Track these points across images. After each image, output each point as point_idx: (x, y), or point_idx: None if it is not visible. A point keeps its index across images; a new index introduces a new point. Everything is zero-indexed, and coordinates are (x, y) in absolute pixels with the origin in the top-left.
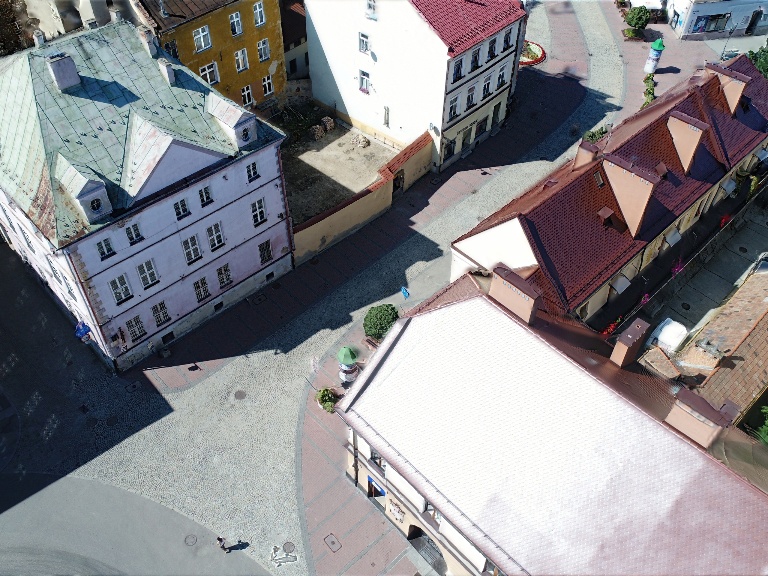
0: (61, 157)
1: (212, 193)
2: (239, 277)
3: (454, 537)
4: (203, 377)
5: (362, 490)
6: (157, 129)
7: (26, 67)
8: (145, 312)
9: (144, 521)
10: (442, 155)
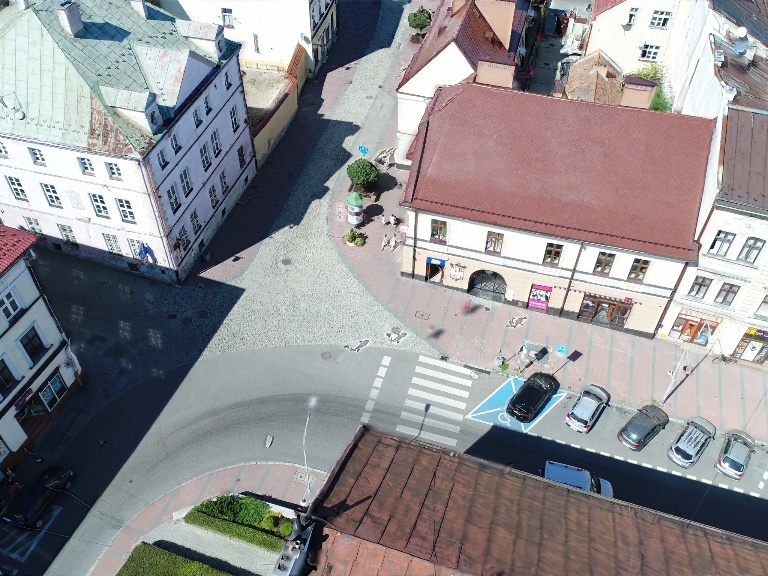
0: (104, 88)
1: (210, 102)
2: (231, 182)
3: (516, 251)
4: (249, 262)
5: (419, 278)
6: (167, 49)
7: (35, 22)
8: (188, 220)
9: (283, 360)
10: (314, 61)
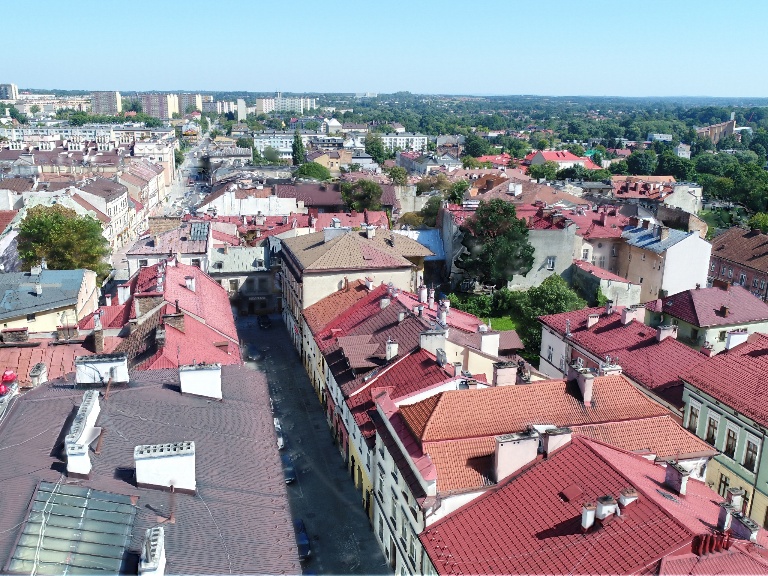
0: None
1: None
2: None
3: None
4: None
5: None
6: None
7: None
8: None
9: None
10: None
